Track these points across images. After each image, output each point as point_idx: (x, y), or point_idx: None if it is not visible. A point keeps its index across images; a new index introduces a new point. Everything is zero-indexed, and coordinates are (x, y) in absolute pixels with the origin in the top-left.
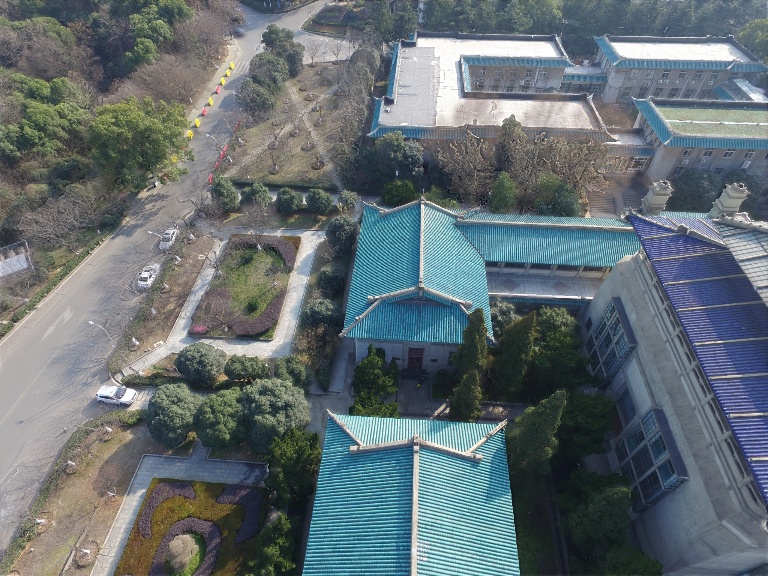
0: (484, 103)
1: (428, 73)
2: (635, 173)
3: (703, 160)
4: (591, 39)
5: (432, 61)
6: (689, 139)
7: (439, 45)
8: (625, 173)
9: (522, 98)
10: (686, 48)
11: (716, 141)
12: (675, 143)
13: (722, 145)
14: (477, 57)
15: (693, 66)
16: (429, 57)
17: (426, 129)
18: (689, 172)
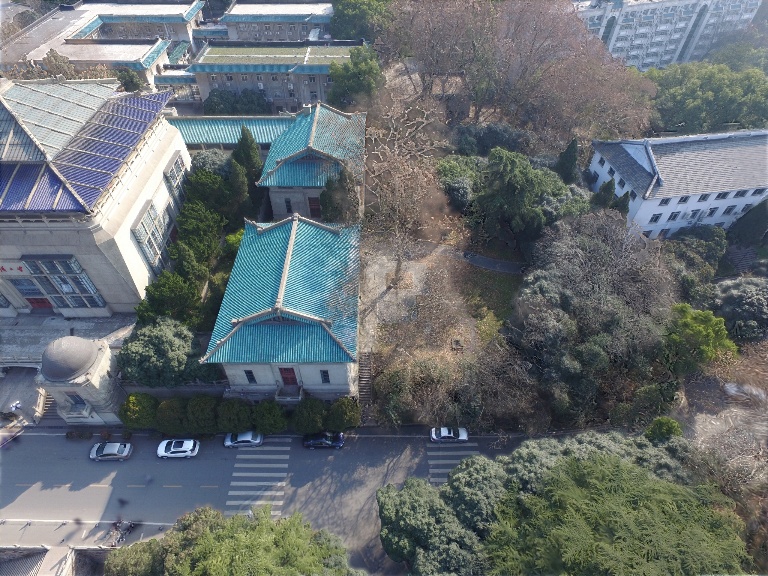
0: (76, 47)
1: (58, 28)
2: (200, 99)
3: (227, 83)
4: (231, 2)
5: (73, 20)
6: (204, 66)
7: (94, 8)
8: (195, 100)
9: (112, 43)
10: (295, 7)
11: (224, 67)
12: (194, 69)
13: (228, 70)
14: (111, 16)
15: (281, 19)
16: (74, 17)
17: (1, 64)
18: (210, 92)
